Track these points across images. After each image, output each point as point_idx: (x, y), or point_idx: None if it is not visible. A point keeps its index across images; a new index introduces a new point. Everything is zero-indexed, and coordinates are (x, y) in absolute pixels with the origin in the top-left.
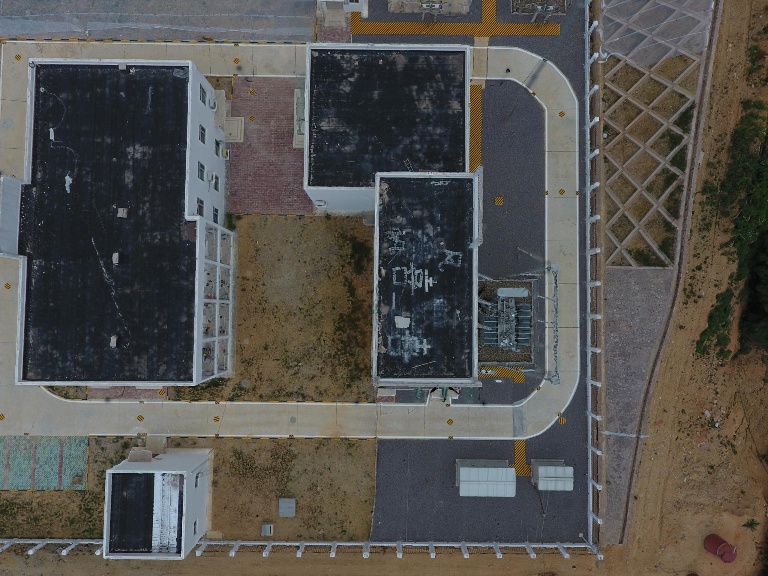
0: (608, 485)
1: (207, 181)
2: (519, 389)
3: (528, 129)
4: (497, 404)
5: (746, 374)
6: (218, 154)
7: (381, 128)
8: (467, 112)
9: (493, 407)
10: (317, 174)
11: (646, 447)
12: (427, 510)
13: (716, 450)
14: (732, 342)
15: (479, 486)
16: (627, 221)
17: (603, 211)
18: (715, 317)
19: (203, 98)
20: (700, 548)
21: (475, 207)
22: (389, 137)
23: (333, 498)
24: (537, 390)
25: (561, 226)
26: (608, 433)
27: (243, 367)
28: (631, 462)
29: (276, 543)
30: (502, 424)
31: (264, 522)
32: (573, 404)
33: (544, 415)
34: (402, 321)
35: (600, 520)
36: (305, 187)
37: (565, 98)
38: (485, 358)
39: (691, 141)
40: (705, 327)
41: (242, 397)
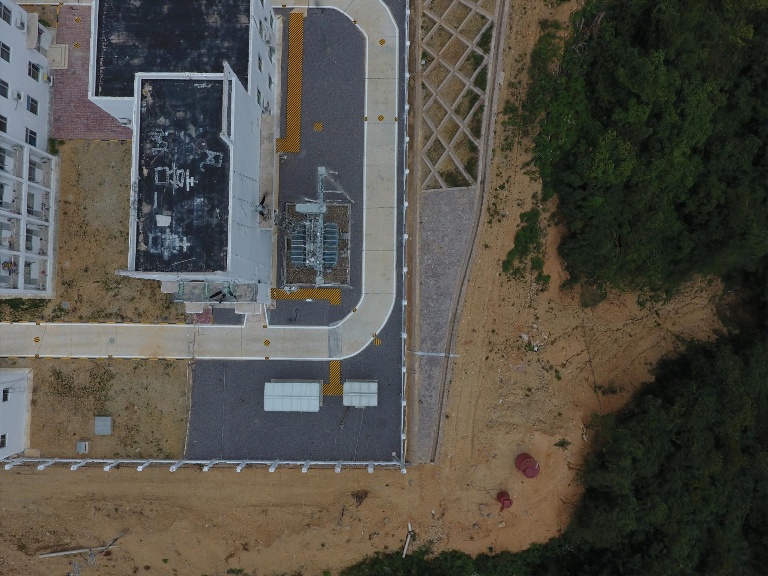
0: (420, 404)
1: (13, 99)
2: (335, 311)
3: (348, 56)
4: (313, 325)
5: (595, 311)
6: (38, 79)
7: (170, 41)
8: (250, 24)
9: (309, 328)
10: (106, 86)
11: (456, 366)
12: (242, 429)
13: (535, 374)
14: (552, 267)
15: (283, 401)
16: (440, 145)
17: (420, 136)
18: (520, 236)
19: (6, 17)
20: (511, 467)
21: (232, 106)
22: (177, 50)
23: (150, 417)
24: (353, 312)
25: (380, 151)
26: (421, 353)
27: (63, 289)
28: (441, 381)
29: (91, 460)
30: (318, 345)
31: (81, 440)
32: (388, 326)
33: (359, 336)
34: (163, 219)
35: (403, 435)
36: (89, 97)
37: (386, 26)
38: (303, 281)
39: (491, 61)
40: (510, 246)
41: (62, 318)
